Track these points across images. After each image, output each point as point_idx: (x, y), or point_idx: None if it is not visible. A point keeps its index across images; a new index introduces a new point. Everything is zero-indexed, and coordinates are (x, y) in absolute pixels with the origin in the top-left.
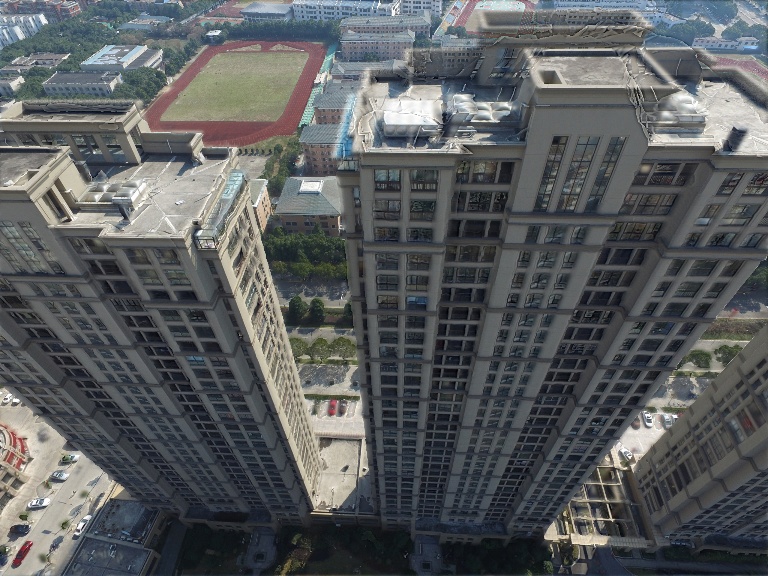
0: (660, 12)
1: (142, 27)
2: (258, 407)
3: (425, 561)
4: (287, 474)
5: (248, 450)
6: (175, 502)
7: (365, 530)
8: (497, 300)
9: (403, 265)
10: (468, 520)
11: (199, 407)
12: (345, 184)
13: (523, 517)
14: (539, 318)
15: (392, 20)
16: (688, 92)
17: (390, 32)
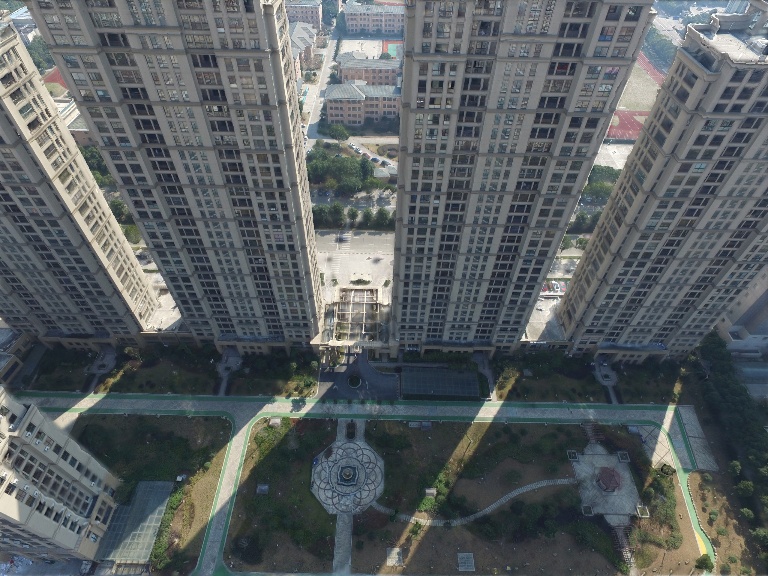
0: None
1: None
2: (51, 201)
3: (227, 366)
4: (103, 281)
5: (61, 250)
6: (32, 320)
7: None
8: (152, 95)
9: (82, 64)
10: (257, 333)
11: (15, 208)
12: (30, 7)
13: (289, 323)
14: (185, 110)
15: None
16: None
17: None
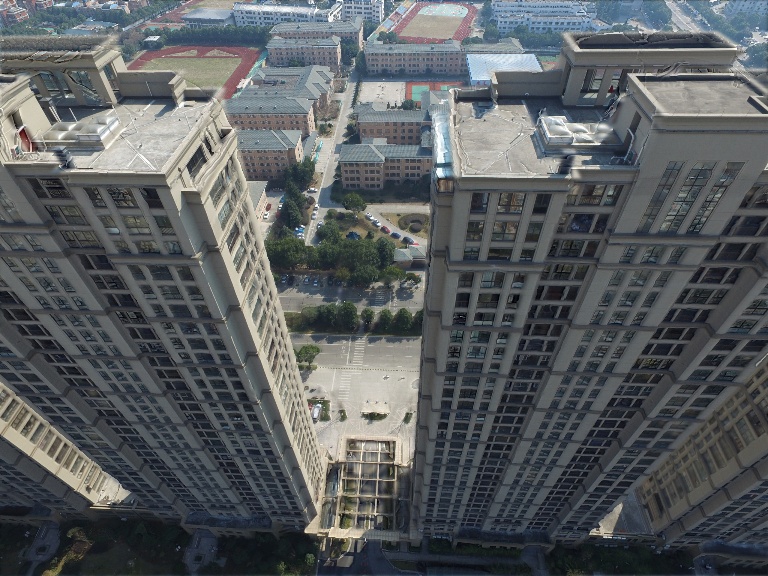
0: (589, 17)
1: (84, 33)
2: None
3: (199, 554)
4: (28, 468)
5: None
6: None
7: (147, 524)
8: (29, 302)
9: None
10: (236, 514)
11: None
12: None
13: (275, 511)
14: (84, 319)
15: (322, 26)
16: (115, 113)
17: (320, 38)
